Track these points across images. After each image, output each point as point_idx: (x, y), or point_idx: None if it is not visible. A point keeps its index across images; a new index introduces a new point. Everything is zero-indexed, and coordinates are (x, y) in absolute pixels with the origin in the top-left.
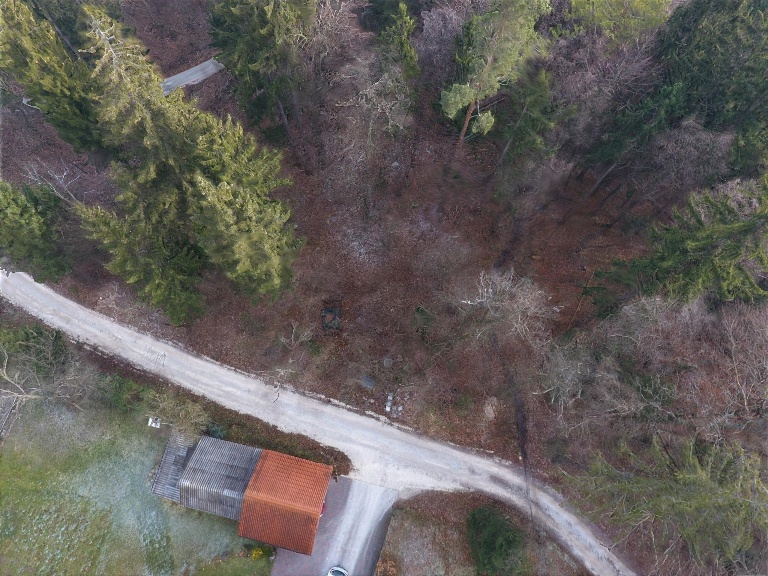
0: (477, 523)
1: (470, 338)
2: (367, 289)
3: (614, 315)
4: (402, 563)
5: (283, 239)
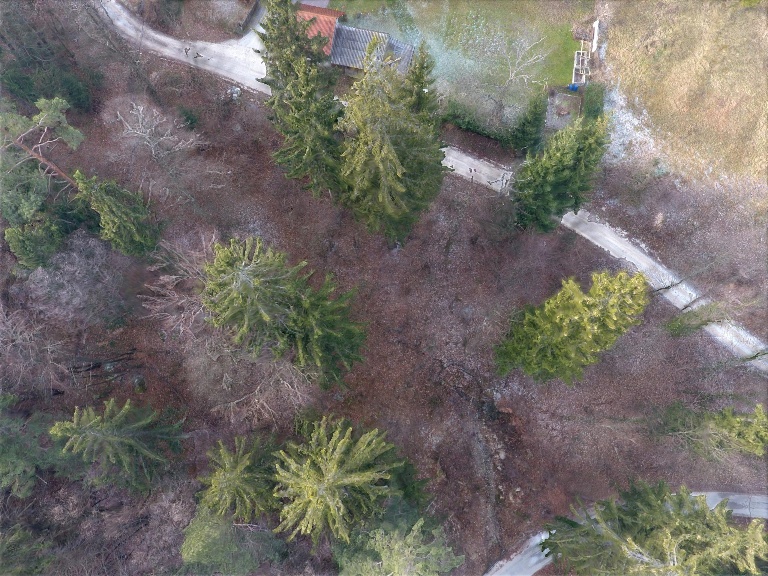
0: (178, 6)
1: (160, 133)
2: (250, 189)
3: (4, 9)
4: (237, 2)
5: (263, 57)
